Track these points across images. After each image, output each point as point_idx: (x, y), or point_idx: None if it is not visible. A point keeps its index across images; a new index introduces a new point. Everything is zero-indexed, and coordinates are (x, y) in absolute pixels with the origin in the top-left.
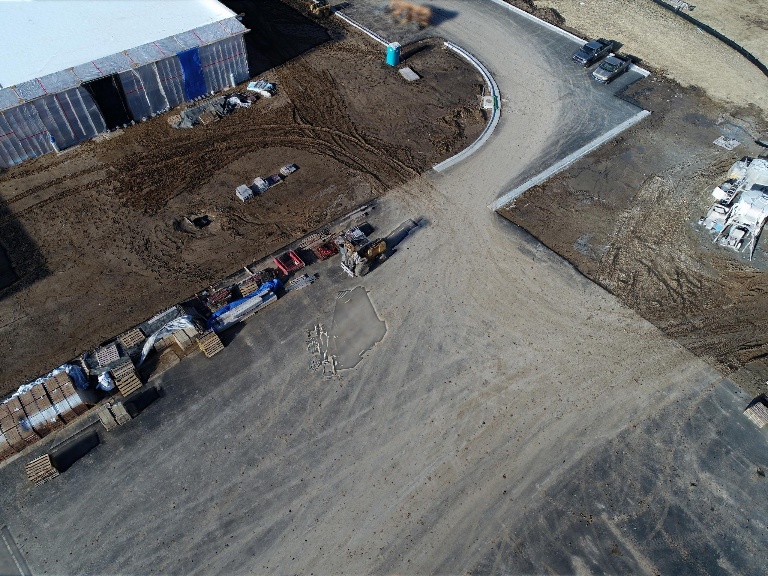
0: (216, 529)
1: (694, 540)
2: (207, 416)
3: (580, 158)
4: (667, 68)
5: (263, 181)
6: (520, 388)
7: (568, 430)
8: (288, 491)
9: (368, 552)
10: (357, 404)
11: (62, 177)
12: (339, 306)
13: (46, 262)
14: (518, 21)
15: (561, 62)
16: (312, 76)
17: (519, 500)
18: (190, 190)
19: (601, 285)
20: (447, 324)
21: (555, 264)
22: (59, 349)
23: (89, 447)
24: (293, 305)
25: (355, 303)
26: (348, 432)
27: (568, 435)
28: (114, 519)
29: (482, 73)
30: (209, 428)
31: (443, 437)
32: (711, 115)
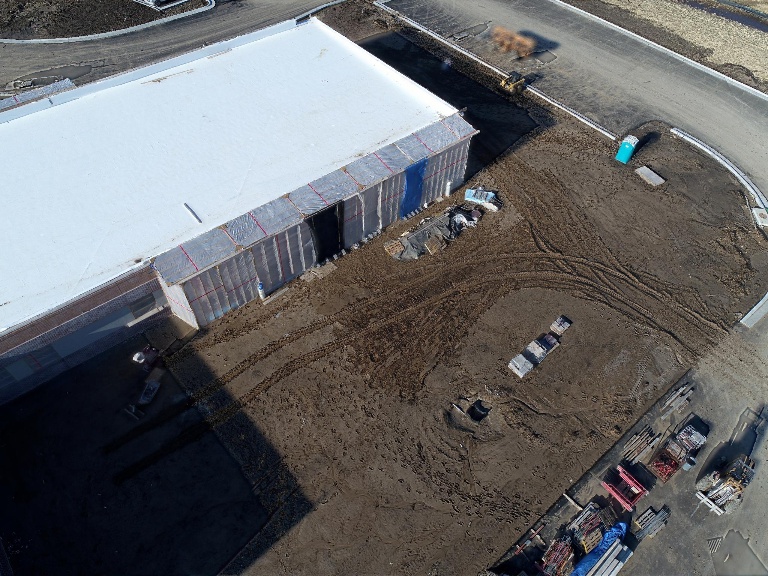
0: None
1: None
2: None
3: None
4: None
5: (541, 348)
6: None
7: None
8: None
9: None
10: None
11: (279, 339)
12: (719, 567)
13: (298, 486)
14: (745, 99)
15: None
16: (534, 179)
17: None
18: (446, 359)
19: None
20: None
21: None
22: None
23: None
24: (656, 565)
25: (739, 562)
26: None
27: None
28: None
29: (734, 173)
30: None
31: None
32: None
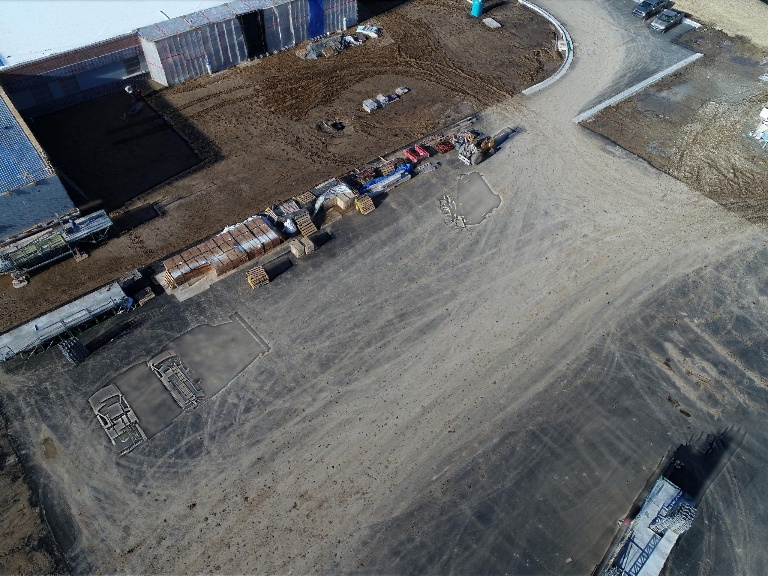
0: (393, 318)
1: (757, 336)
2: (371, 251)
3: (645, 87)
4: (715, 22)
5: (384, 97)
6: (613, 240)
7: (654, 267)
8: (443, 297)
9: (510, 334)
10: (486, 246)
11: (219, 92)
12: (461, 184)
13: (221, 150)
14: None
15: (622, 16)
16: (409, 23)
17: (620, 308)
18: (324, 104)
19: (671, 175)
20: (549, 198)
21: (632, 160)
22: (246, 207)
23: (286, 267)
24: (424, 183)
25: (473, 182)
26: (482, 263)
27: (654, 270)
28: (316, 310)
29: (554, 23)
30: (374, 258)
31: (556, 268)
32: (756, 58)
